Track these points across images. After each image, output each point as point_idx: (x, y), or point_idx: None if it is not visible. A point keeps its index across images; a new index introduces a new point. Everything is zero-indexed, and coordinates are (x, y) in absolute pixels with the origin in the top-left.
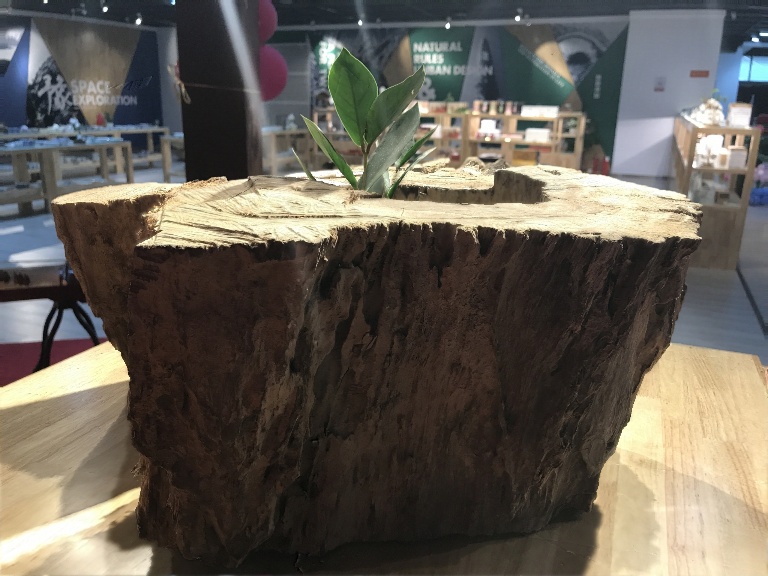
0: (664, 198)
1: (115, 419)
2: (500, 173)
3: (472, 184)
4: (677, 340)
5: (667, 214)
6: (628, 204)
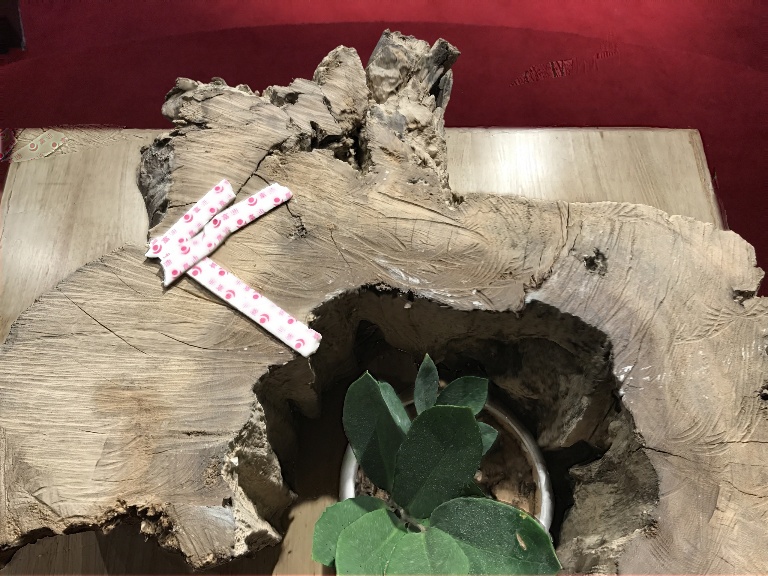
0: (739, 292)
1: None
2: (535, 305)
3: (473, 267)
4: (618, 134)
5: None
6: (720, 384)
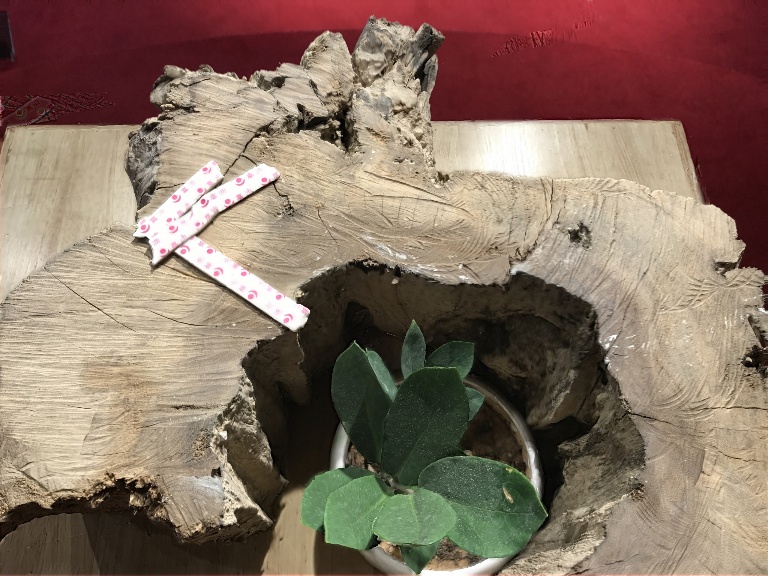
0: (720, 263)
1: (96, 569)
2: (520, 276)
3: (459, 242)
4: (602, 126)
5: (760, 399)
6: (704, 352)
